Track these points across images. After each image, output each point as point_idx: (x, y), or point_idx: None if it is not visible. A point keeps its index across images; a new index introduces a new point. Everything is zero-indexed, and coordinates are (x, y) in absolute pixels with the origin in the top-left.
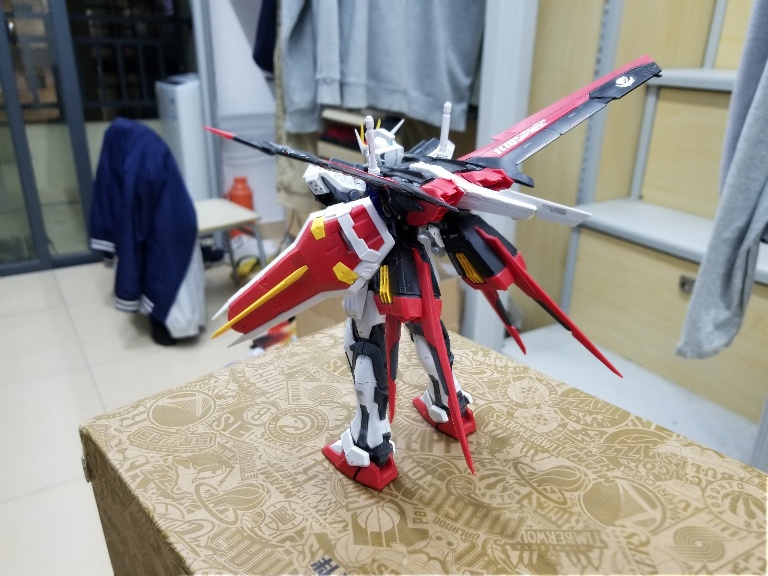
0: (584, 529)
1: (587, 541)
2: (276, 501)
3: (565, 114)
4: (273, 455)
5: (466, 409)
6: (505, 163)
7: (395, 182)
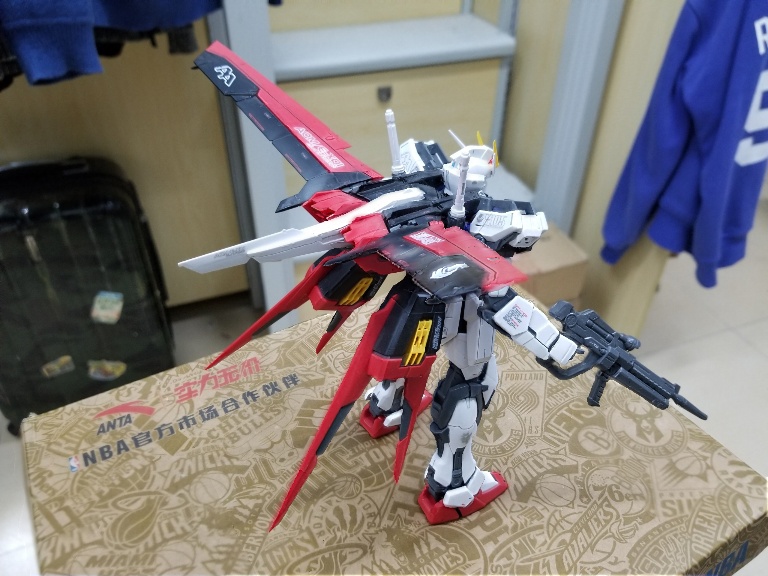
0: (250, 575)
1: (236, 570)
2: None
3: (430, 249)
4: None
5: (440, 499)
6: (385, 242)
7: (327, 168)
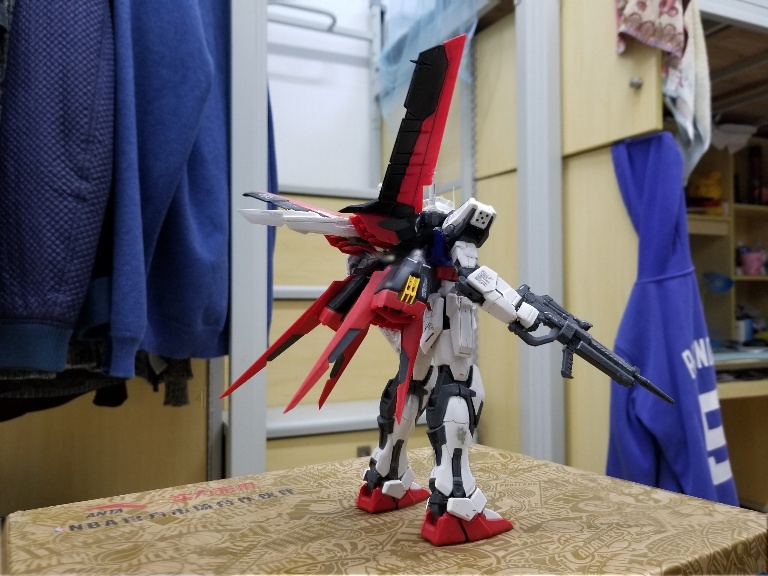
0: (243, 574)
1: (227, 572)
2: (362, 482)
3: None
4: (419, 481)
5: (443, 513)
6: None
7: None
